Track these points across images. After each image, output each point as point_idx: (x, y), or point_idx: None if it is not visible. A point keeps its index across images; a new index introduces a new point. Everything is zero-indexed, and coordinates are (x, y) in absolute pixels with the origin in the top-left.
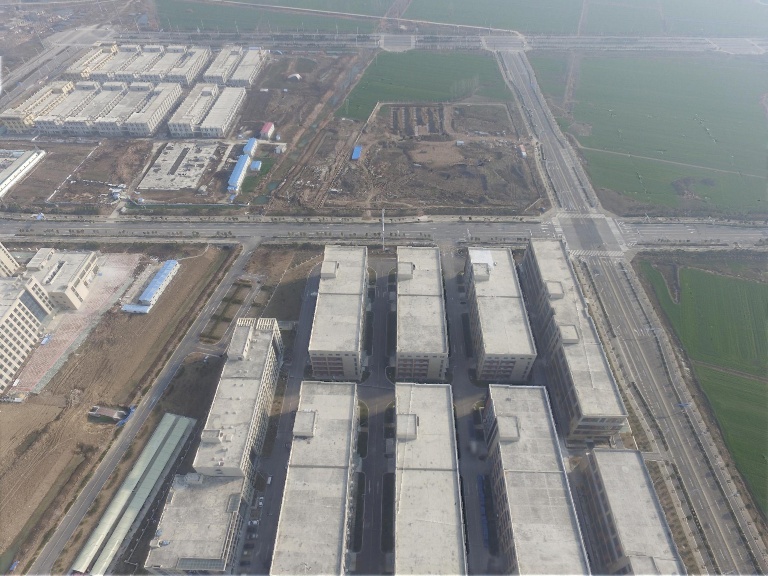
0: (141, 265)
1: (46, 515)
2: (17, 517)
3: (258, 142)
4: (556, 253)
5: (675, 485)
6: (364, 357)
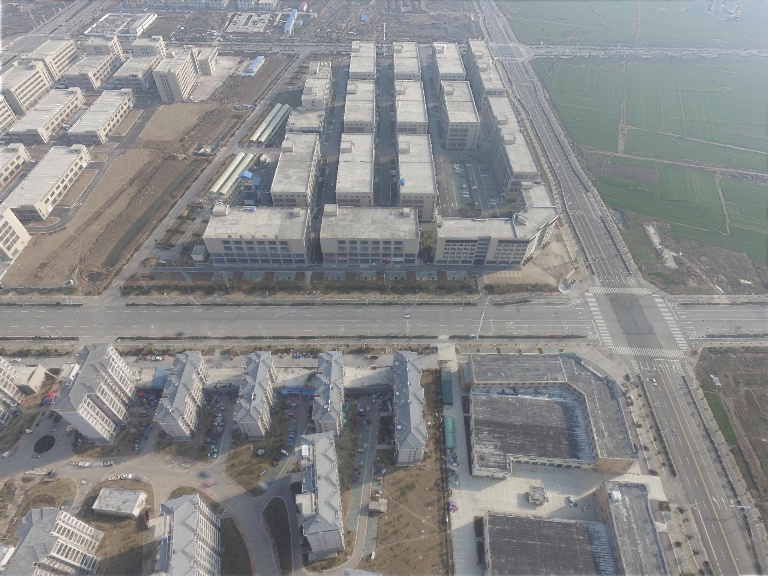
0: (241, 60)
1: (227, 132)
2: (214, 132)
3: (298, 13)
4: (482, 45)
5: (530, 124)
6: (377, 87)
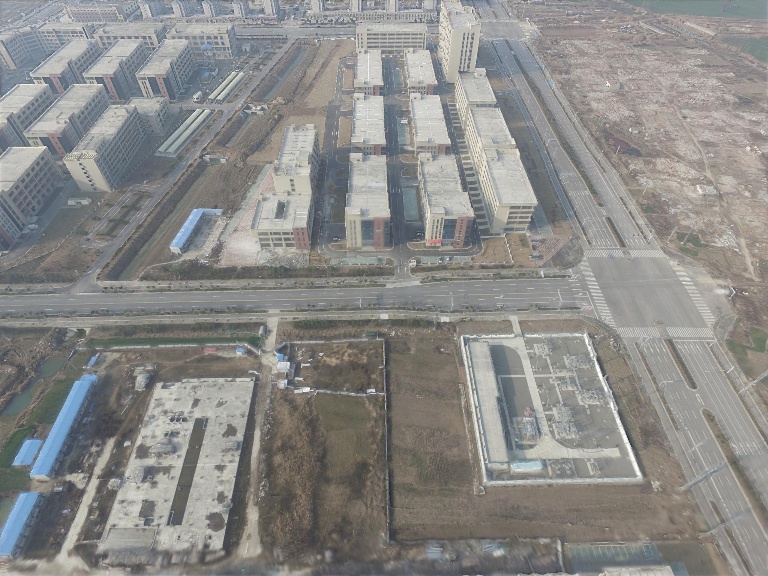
0: (216, 253)
1: (236, 128)
2: None
3: None
4: None
5: None
6: None
